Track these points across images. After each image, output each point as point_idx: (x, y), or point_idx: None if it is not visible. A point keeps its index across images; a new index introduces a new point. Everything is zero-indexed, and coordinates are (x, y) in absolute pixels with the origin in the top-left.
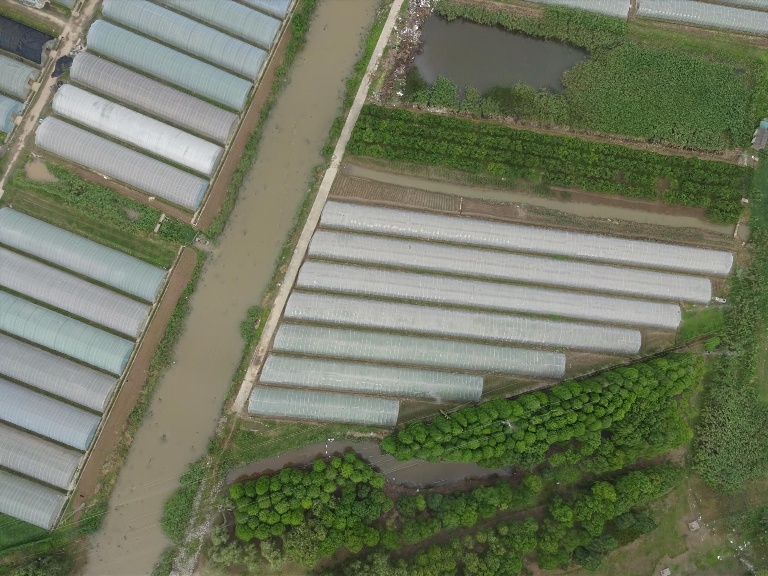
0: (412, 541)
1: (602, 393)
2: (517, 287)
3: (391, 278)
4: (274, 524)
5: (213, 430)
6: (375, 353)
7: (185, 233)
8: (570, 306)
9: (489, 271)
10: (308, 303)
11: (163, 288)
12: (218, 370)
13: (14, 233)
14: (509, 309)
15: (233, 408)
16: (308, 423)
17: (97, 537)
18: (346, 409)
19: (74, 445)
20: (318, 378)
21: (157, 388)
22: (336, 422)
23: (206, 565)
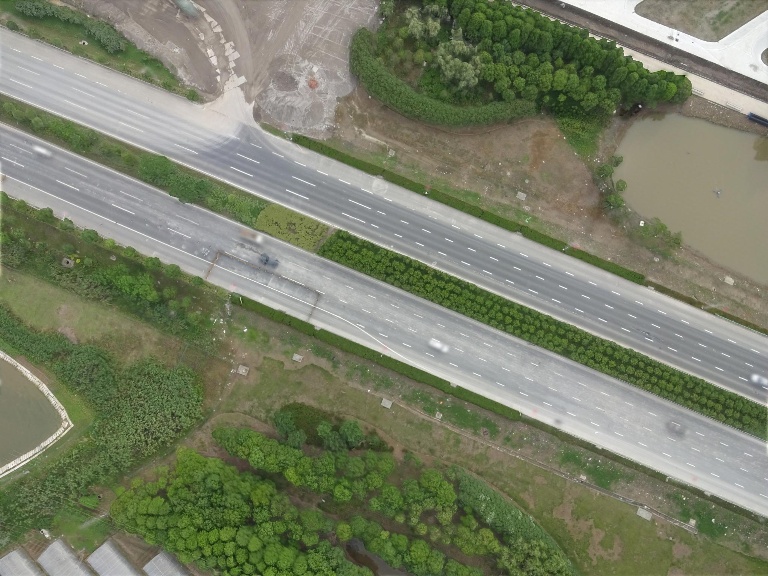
0: None
1: (226, 569)
2: None
3: None
4: None
5: None
6: None
7: None
8: None
9: None
10: None
11: None
12: None
13: None
14: None
15: None
16: None
17: None
18: None
19: None
20: None
21: None
22: None
23: None
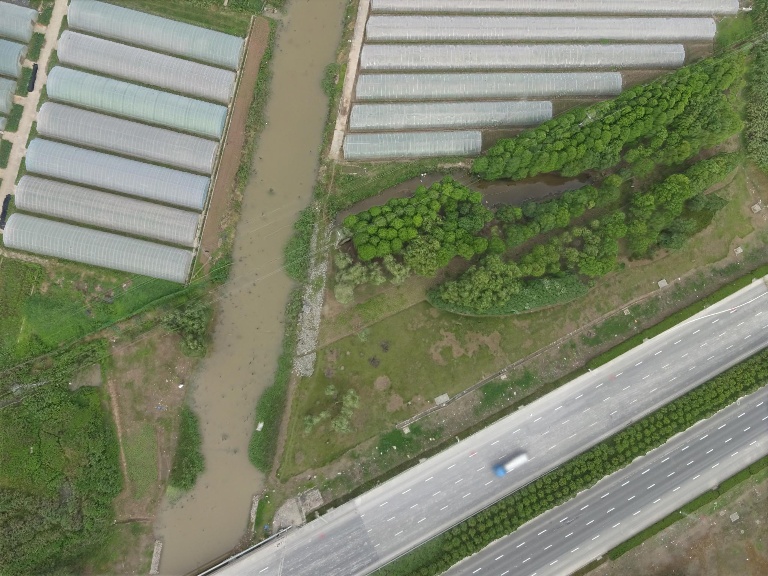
0: (517, 242)
1: (662, 89)
2: (566, 18)
3: (451, 23)
4: (393, 238)
5: (315, 180)
6: (450, 91)
7: (253, 4)
8: (616, 30)
9: (539, 5)
10: (381, 51)
11: (243, 56)
12: (308, 126)
13: (94, 16)
14: (563, 38)
15: (330, 156)
16: (401, 161)
17: (228, 287)
18: (434, 141)
19: (191, 204)
20: (403, 117)
21: (256, 148)
22: (426, 157)
23: (337, 287)
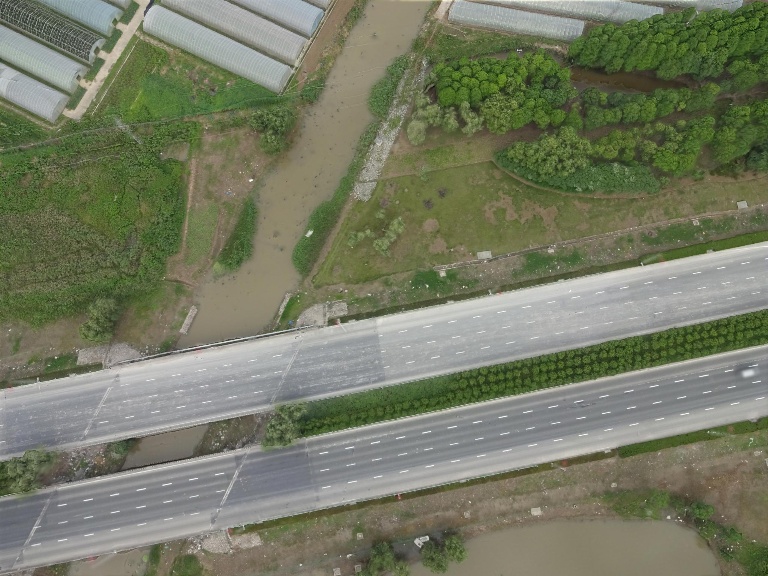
0: (595, 121)
1: None
2: None
3: None
4: None
5: (416, 34)
6: None
7: None
8: None
9: None
10: None
11: None
12: None
13: None
14: None
15: (435, 15)
16: (500, 33)
17: (315, 108)
18: (536, 20)
19: (303, 28)
20: None
21: None
22: (525, 34)
23: None
